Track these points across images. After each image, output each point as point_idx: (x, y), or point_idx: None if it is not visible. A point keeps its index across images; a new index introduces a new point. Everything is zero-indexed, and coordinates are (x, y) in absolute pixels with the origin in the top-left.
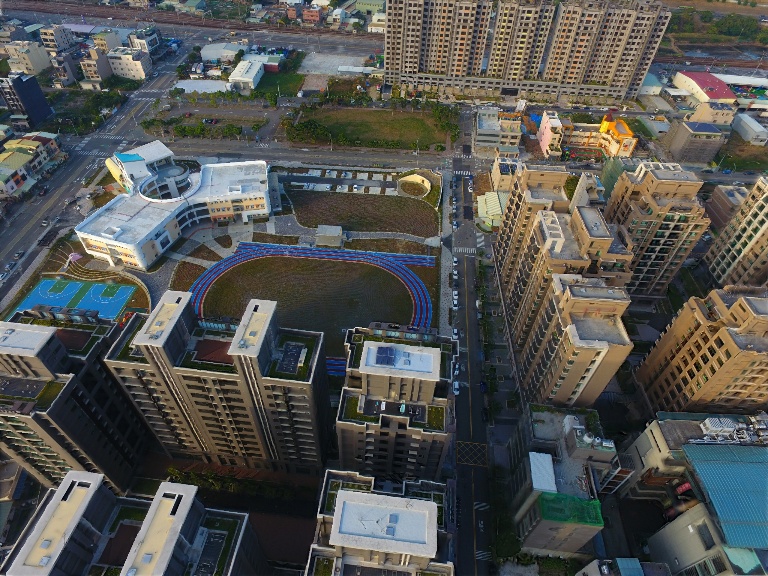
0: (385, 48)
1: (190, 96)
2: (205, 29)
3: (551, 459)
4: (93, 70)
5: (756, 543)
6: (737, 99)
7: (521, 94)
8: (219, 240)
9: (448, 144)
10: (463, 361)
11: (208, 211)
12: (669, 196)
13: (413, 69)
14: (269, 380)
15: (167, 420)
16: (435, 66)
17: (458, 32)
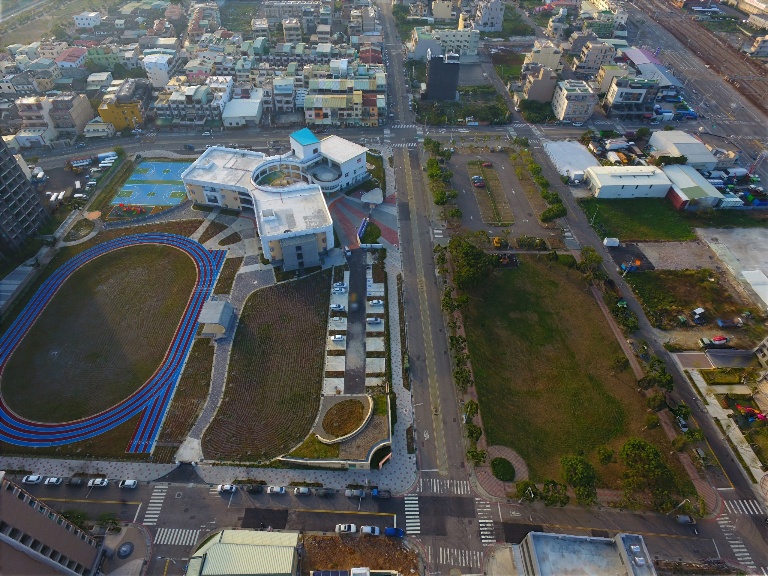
0: None
1: None
2: (766, 124)
3: None
4: None
5: None
6: None
7: None
8: (233, 236)
9: None
10: None
11: None
12: None
13: None
14: None
15: None
16: None
17: None
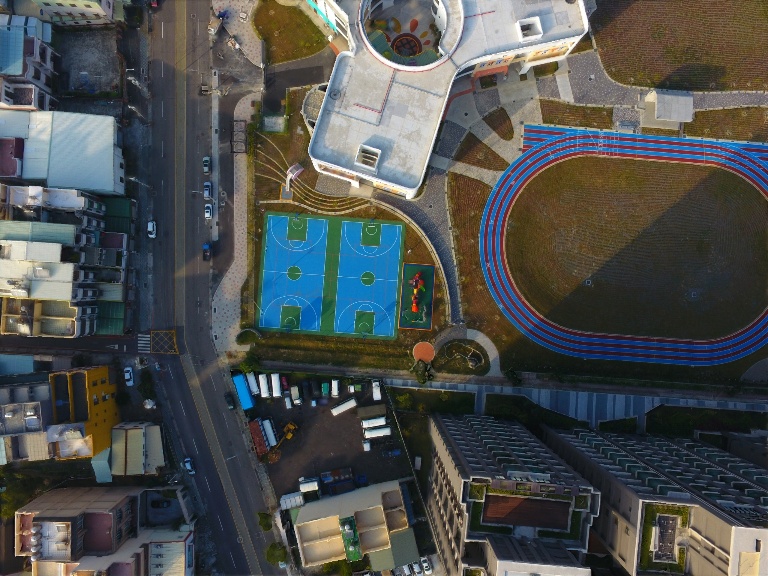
0: None
1: None
2: None
3: None
4: None
5: None
6: None
7: None
8: (492, 121)
9: None
10: None
11: (474, 67)
12: None
13: None
14: None
15: None
16: None
17: None
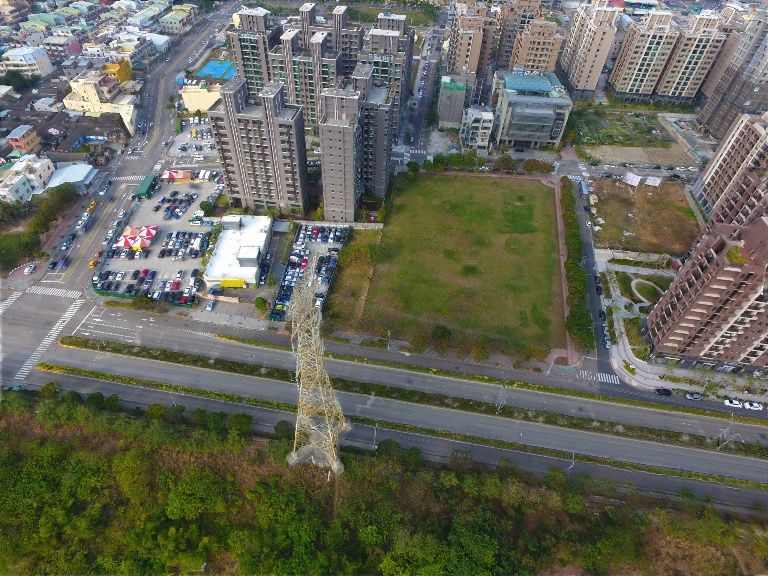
0: None
1: None
2: None
3: (450, 77)
4: None
5: (517, 87)
6: (625, 8)
7: None
8: None
9: (431, 24)
10: (425, 90)
11: None
12: (527, 8)
13: None
14: (344, 30)
15: None
16: None
17: None
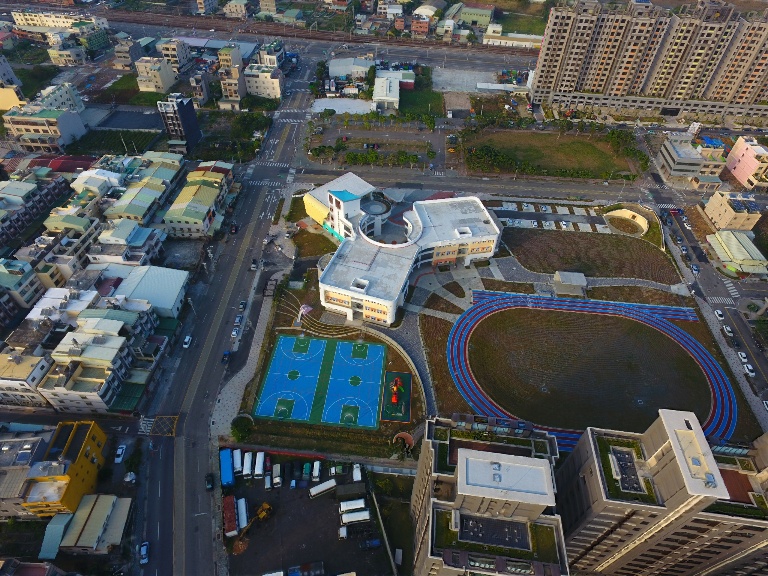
0: (540, 66)
1: (341, 118)
2: (314, 41)
3: None
4: (233, 89)
5: None
6: None
7: (682, 114)
8: (449, 288)
9: (634, 172)
10: None
11: (432, 255)
12: None
13: (569, 88)
14: None
15: (589, 547)
16: (591, 84)
17: (627, 49)
